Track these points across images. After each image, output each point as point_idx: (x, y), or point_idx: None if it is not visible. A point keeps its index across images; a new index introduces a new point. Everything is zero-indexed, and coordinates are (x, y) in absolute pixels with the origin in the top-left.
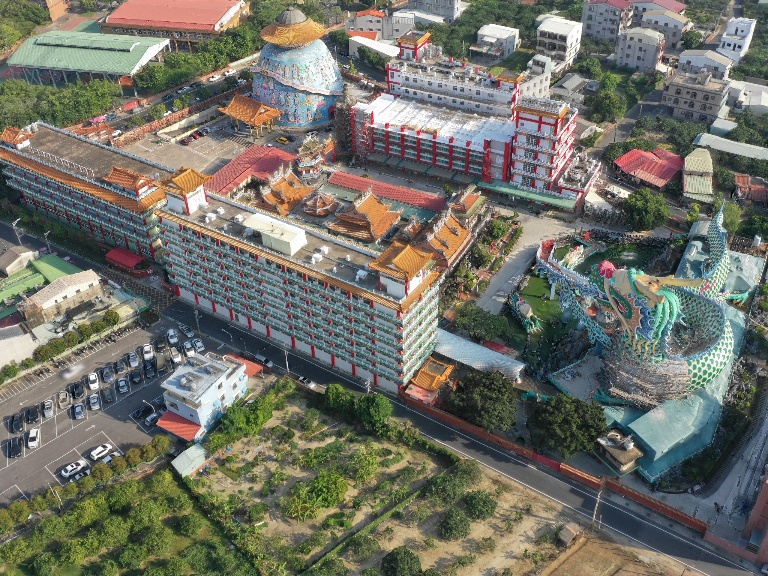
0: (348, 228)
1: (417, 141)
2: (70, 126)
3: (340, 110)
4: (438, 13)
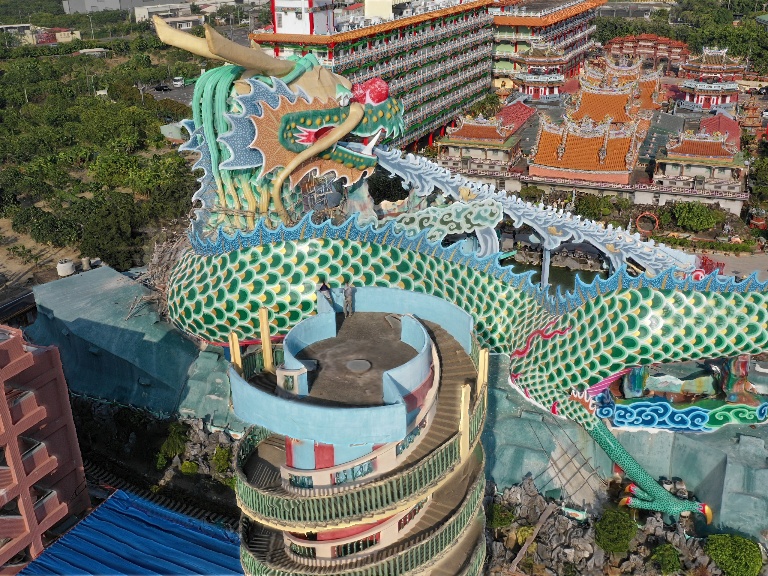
0: None
1: None
2: None
3: None
4: None
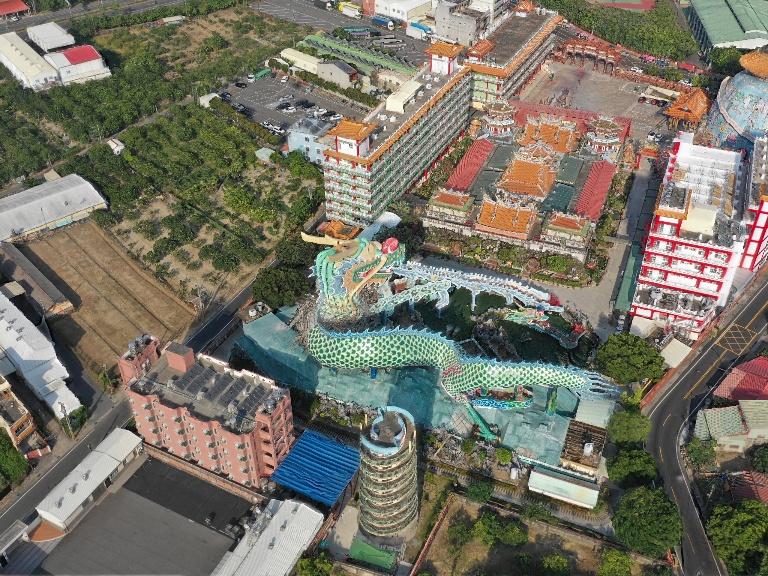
0: None
1: None
2: (633, 51)
3: None
4: None
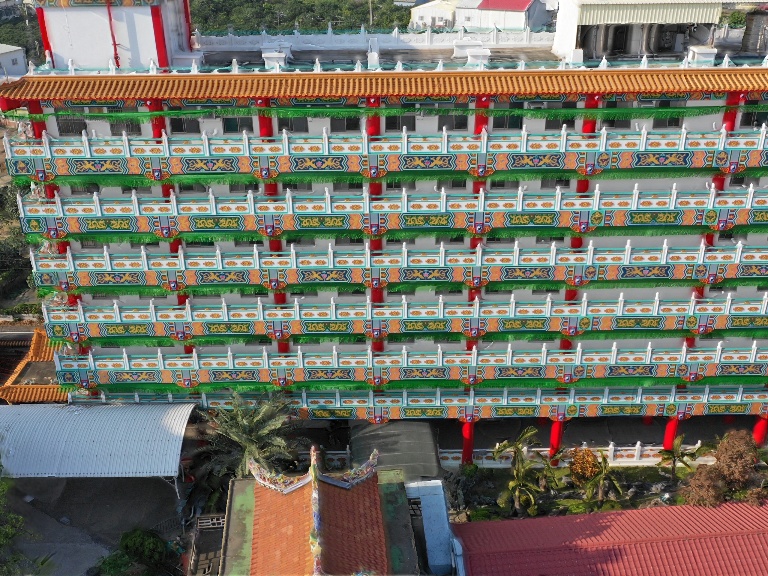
0: None
1: None
2: None
3: None
4: None
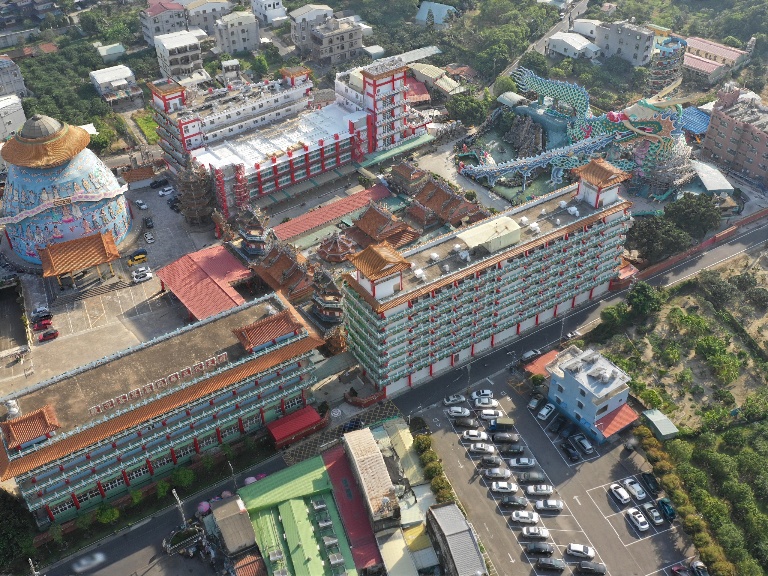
0: (391, 243)
1: (291, 163)
2: None
3: (192, 184)
4: (4, 93)
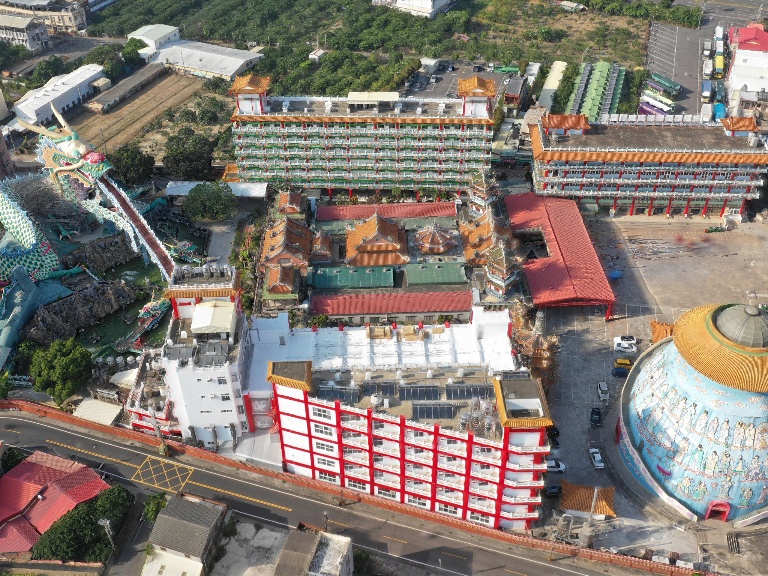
0: None
1: None
2: None
3: None
4: None
